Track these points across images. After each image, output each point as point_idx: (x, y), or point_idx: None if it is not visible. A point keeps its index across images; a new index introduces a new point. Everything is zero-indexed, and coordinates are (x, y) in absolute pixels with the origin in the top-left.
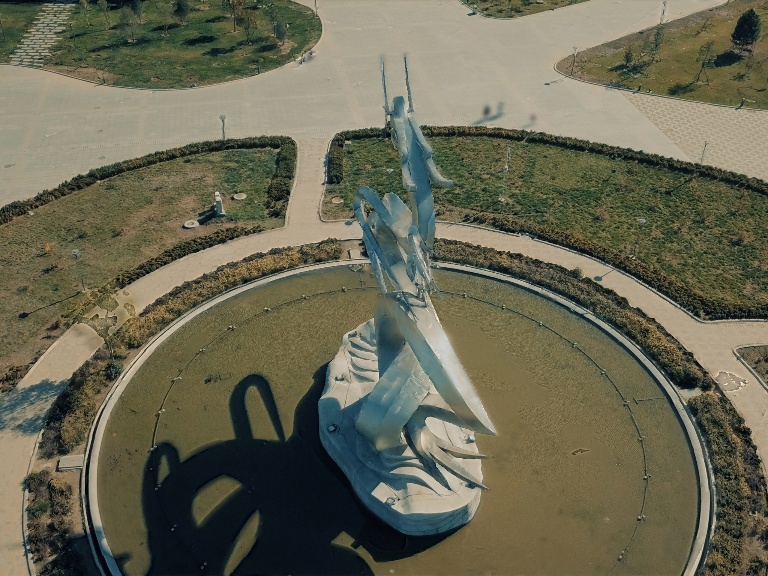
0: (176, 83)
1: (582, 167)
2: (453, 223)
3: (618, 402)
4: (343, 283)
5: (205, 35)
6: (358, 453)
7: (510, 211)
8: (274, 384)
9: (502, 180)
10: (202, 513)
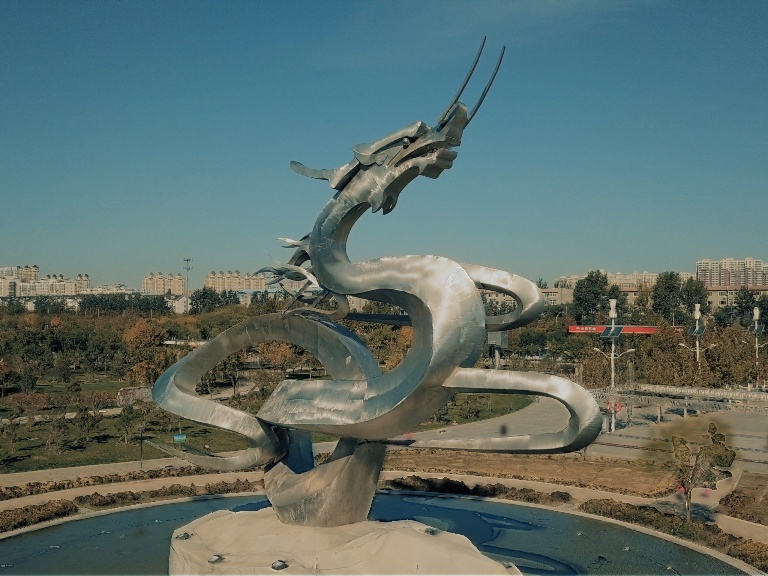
0: None
1: None
2: None
3: None
4: None
5: None
6: None
7: None
8: None
9: None
10: None
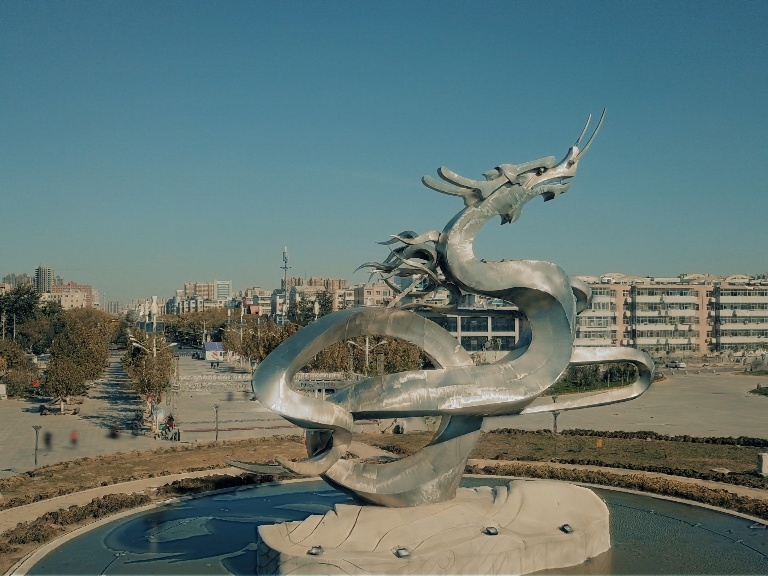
0: None
1: None
2: None
3: None
4: (712, 525)
5: None
6: None
7: None
8: None
9: None
10: (285, 506)
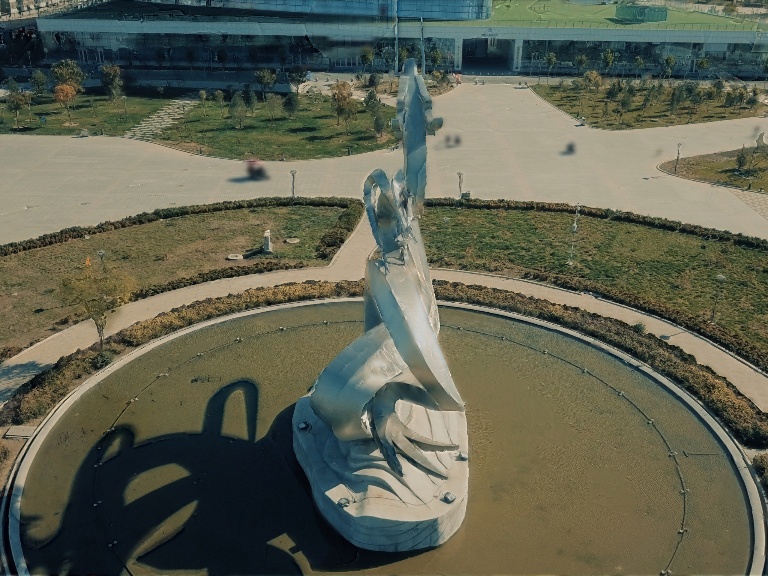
0: (267, 157)
1: (668, 244)
2: (509, 278)
3: (662, 452)
4: None
5: (308, 126)
6: (324, 453)
7: (577, 273)
8: (263, 391)
9: (575, 248)
10: (134, 495)
